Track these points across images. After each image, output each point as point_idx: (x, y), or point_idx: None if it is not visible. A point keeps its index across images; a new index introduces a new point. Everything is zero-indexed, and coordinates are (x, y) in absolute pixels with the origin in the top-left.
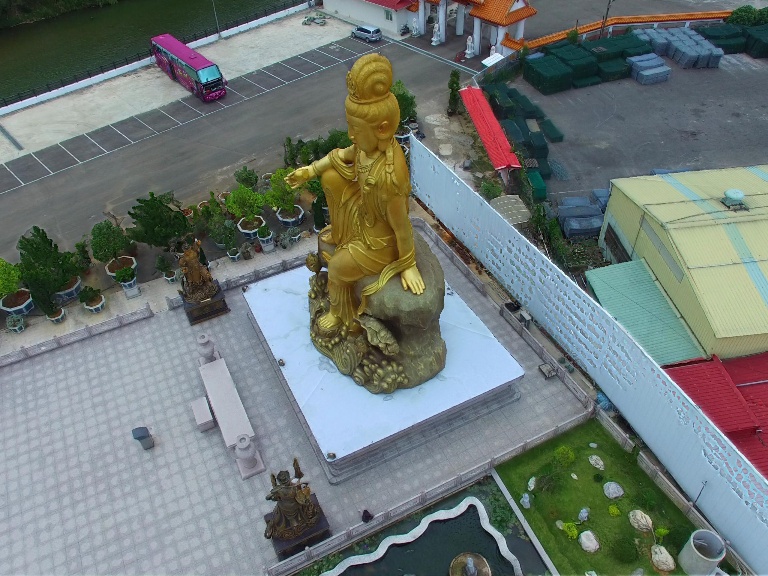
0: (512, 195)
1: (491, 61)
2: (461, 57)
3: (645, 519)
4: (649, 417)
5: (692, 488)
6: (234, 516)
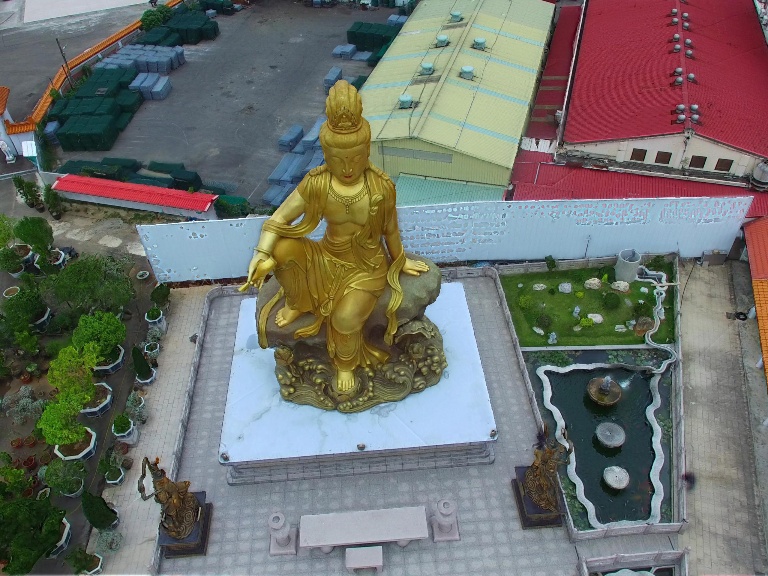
0: (248, 216)
1: (31, 151)
2: None
3: (596, 280)
4: (528, 240)
5: (577, 252)
6: (499, 558)
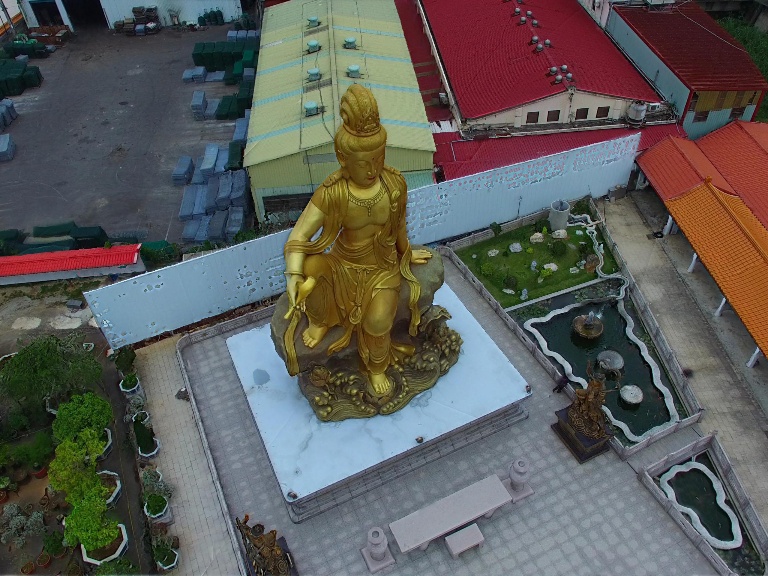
0: (184, 257)
1: None
2: None
3: (539, 234)
4: None
5: (511, 214)
6: (573, 496)
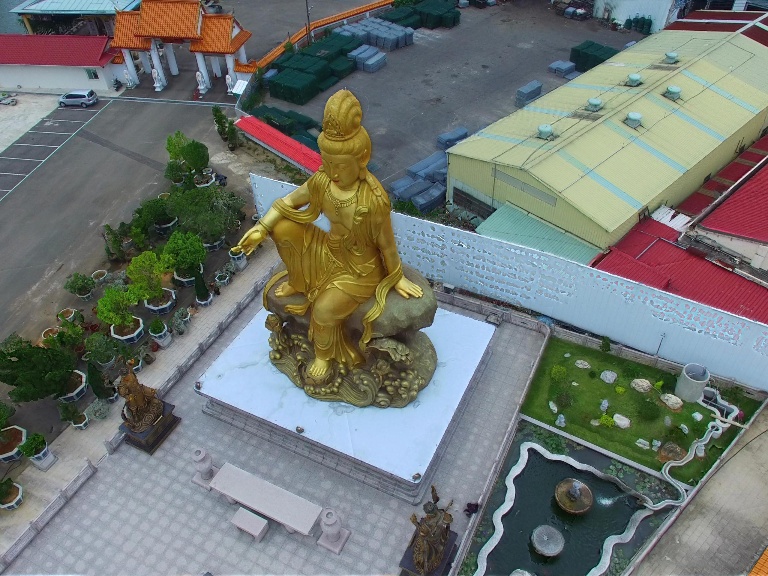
0: None
1: (240, 89)
2: (197, 94)
3: (645, 382)
4: (596, 312)
5: (650, 346)
6: None
